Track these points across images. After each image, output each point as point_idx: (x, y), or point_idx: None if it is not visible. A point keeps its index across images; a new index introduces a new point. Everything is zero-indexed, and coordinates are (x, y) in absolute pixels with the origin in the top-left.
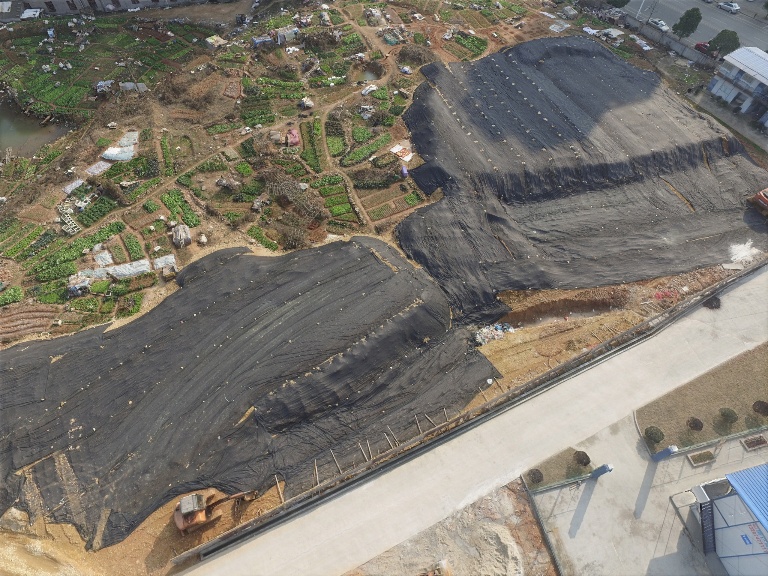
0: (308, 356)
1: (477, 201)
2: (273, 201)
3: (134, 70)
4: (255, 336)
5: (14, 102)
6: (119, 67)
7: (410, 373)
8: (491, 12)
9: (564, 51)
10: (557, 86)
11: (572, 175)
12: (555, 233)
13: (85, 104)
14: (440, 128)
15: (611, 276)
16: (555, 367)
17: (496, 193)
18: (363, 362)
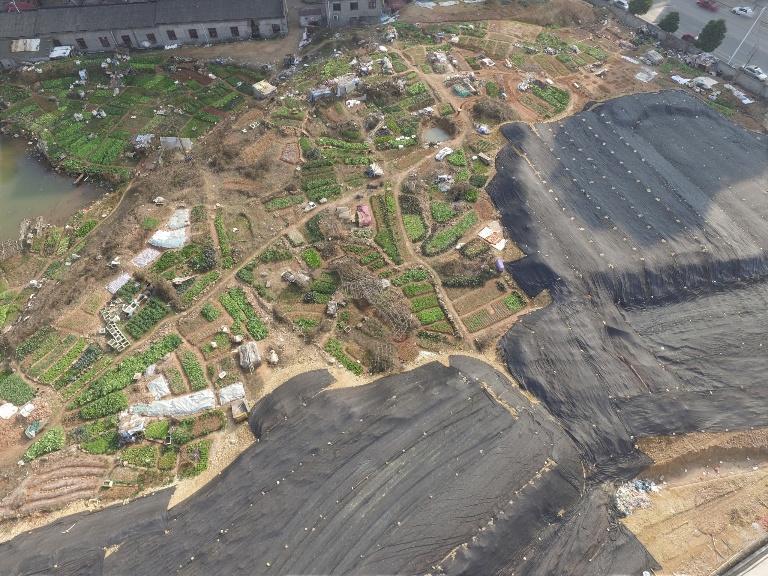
0: (424, 547)
1: (592, 308)
2: (349, 301)
3: (174, 119)
4: (355, 515)
5: (43, 156)
6: (158, 116)
7: (546, 563)
8: (569, 58)
9: (663, 110)
10: (661, 154)
11: (699, 274)
12: (688, 350)
13: (122, 161)
14: (537, 210)
15: (766, 413)
16: (730, 560)
17: (612, 297)
18: (492, 555)
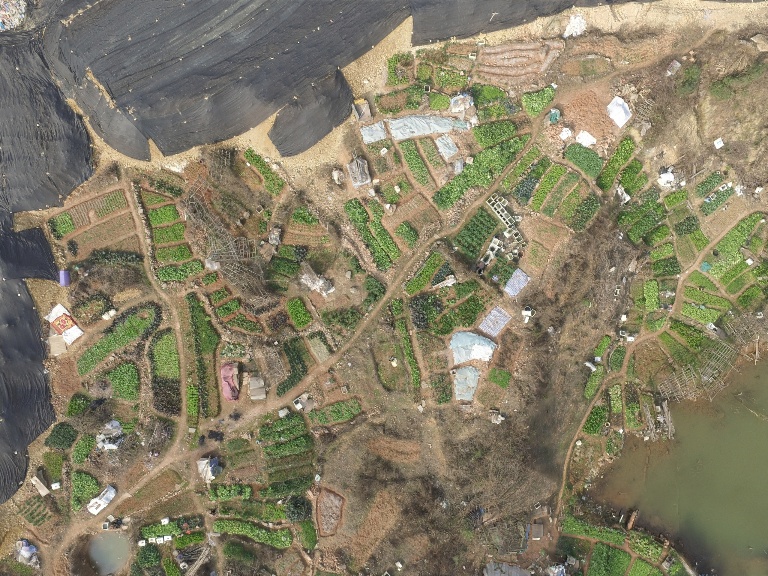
0: None
1: None
2: None
3: None
4: None
5: (693, 570)
6: None
7: None
8: None
9: None
10: None
11: None
12: None
13: (581, 550)
14: None
15: None
16: None
17: None
18: None
